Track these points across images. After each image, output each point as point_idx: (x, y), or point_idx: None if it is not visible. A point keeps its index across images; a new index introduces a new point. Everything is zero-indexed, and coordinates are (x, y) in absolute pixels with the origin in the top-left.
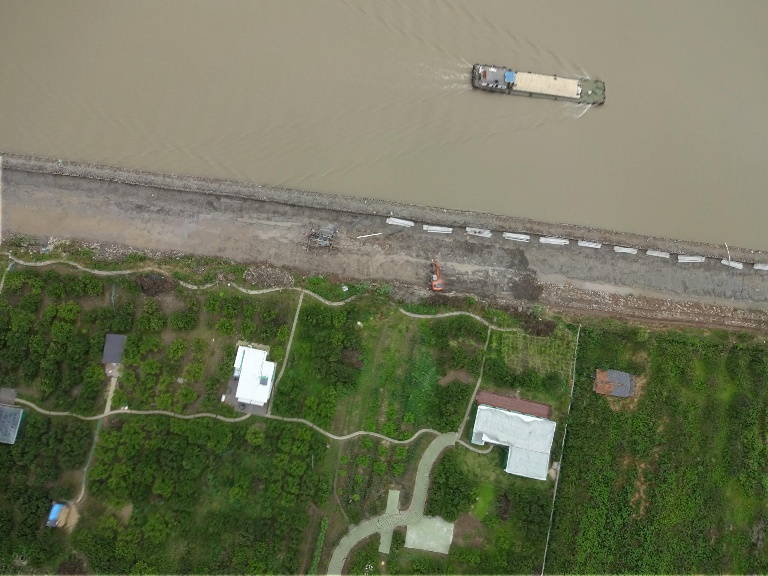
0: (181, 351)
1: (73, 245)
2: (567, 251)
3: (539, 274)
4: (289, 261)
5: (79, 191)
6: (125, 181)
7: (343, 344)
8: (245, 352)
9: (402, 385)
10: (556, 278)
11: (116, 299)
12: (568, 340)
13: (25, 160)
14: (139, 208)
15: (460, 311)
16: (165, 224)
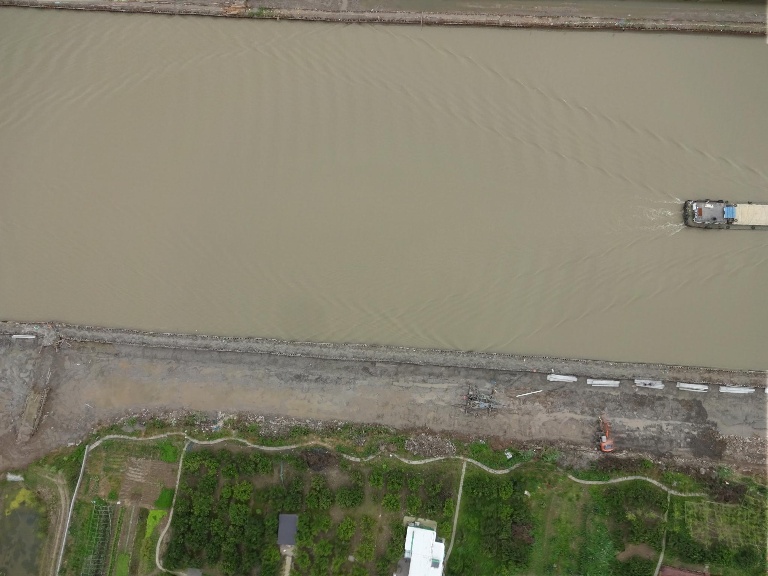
0: (351, 532)
1: (240, 420)
2: (752, 399)
3: (720, 426)
4: (448, 425)
5: (242, 364)
6: (284, 354)
7: (512, 519)
8: (414, 533)
9: (577, 561)
10: (740, 430)
11: (284, 475)
12: (762, 508)
13: (192, 339)
14: (298, 378)
15: (634, 475)
16: (324, 392)
